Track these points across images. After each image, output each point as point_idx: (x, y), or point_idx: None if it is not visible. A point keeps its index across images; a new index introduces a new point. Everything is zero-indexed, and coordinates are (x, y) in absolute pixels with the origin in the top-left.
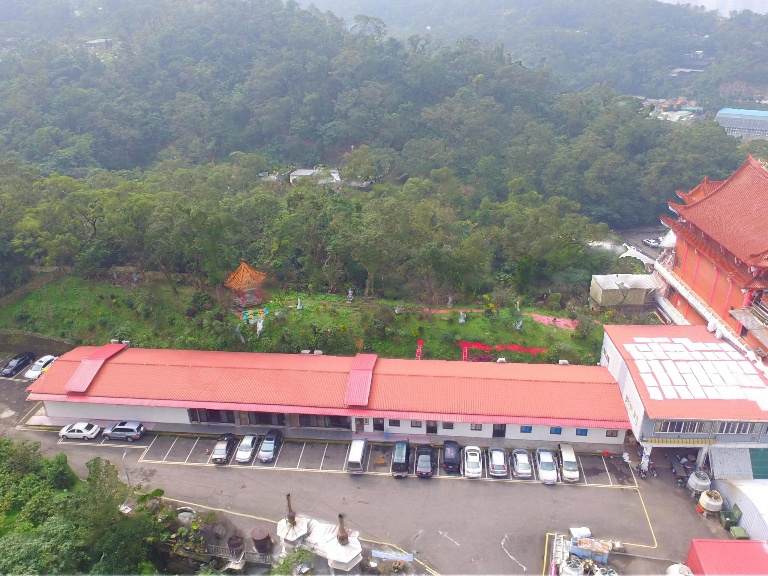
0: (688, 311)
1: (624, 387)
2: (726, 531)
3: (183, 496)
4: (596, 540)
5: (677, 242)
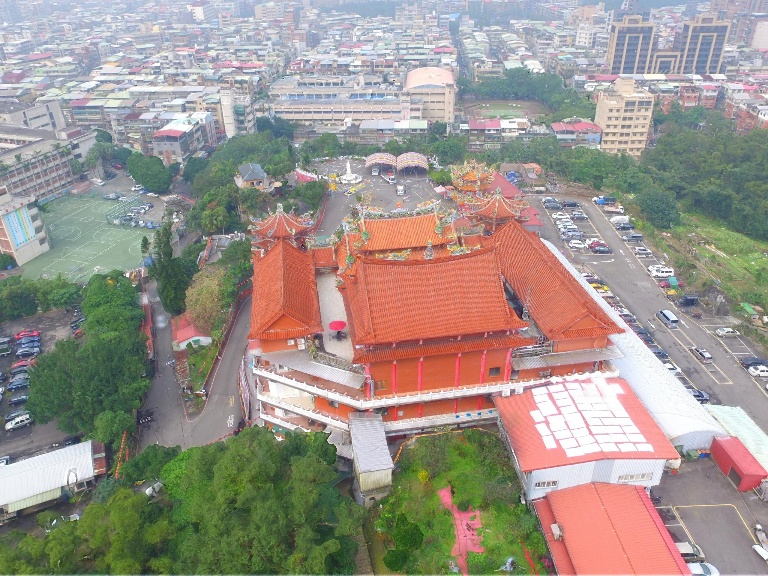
0: None
1: (612, 475)
2: (686, 463)
3: None
4: (763, 542)
5: (371, 370)
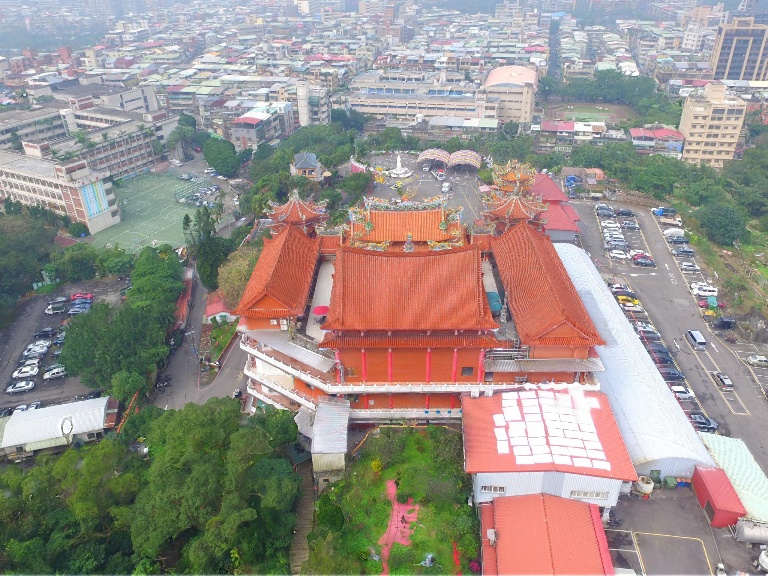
0: (393, 401)
1: (563, 489)
2: (662, 489)
3: None
4: None
5: (340, 356)
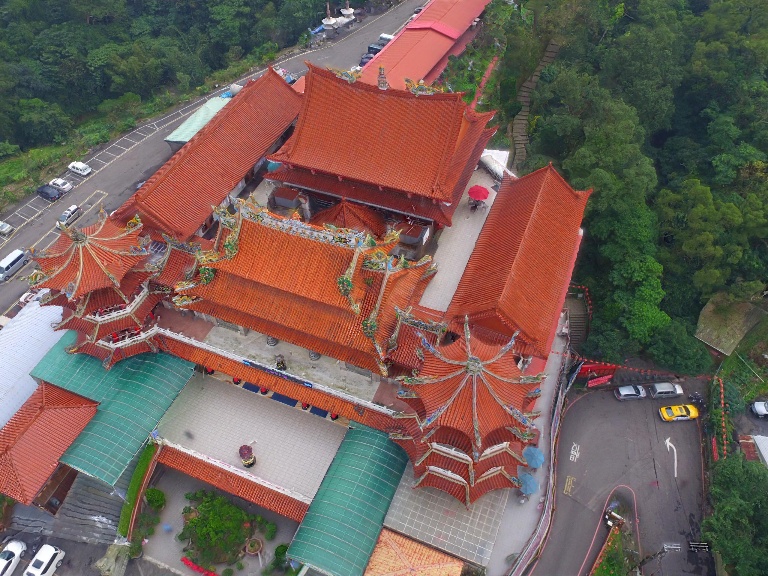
0: None
1: None
2: None
3: (402, 5)
4: None
5: None
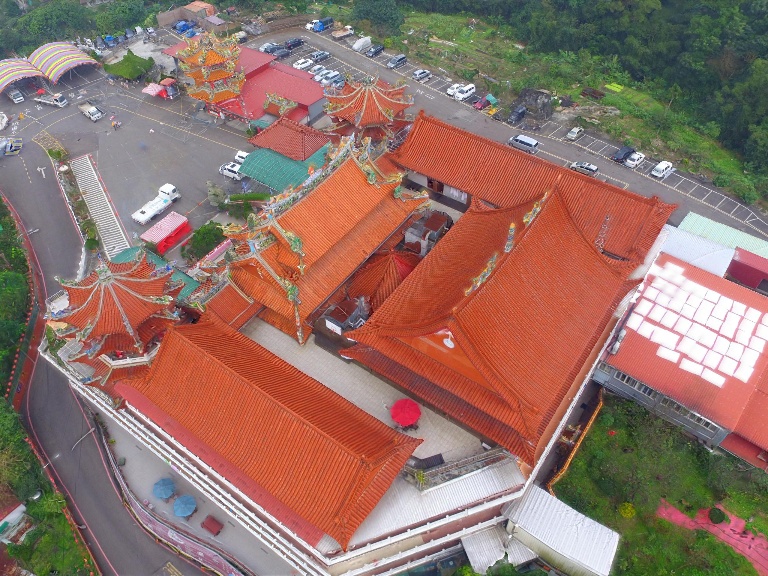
0: None
1: None
2: None
3: None
4: None
5: None
